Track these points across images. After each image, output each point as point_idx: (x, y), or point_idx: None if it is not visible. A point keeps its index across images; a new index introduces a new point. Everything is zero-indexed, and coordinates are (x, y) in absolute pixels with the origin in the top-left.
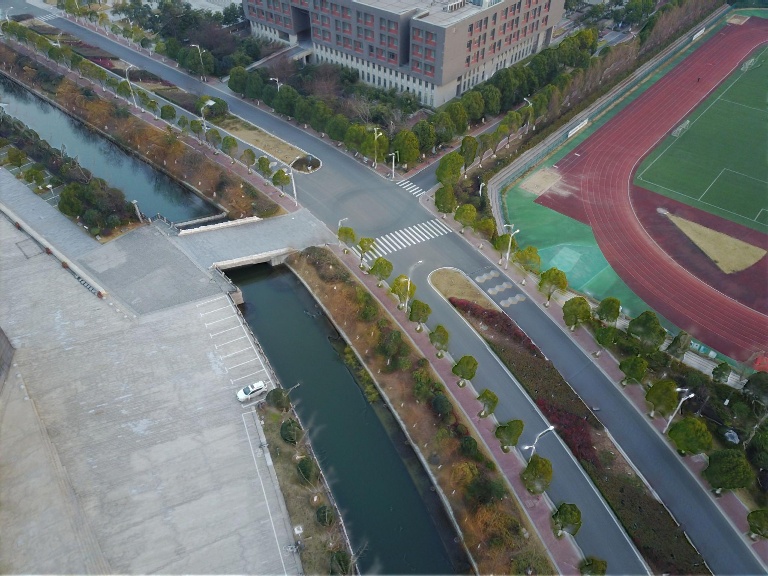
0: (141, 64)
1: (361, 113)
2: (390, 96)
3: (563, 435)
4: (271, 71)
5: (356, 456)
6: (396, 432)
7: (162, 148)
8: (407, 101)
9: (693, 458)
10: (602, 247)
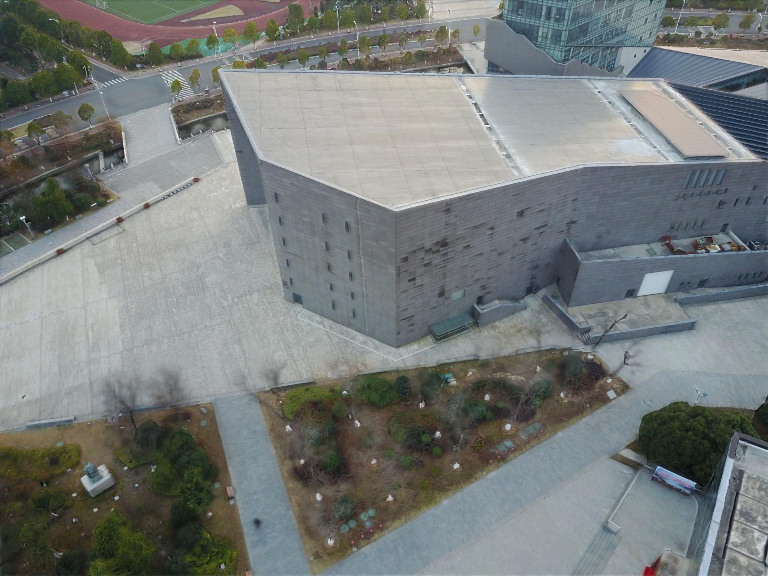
0: None
1: (8, 78)
2: None
3: (339, 49)
4: None
5: None
6: None
7: None
8: None
9: (352, 31)
10: None
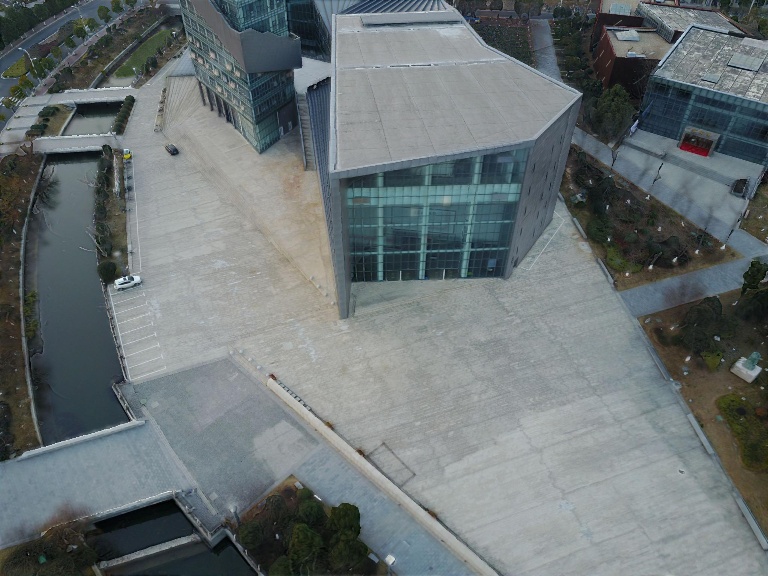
0: None
1: None
2: None
3: None
4: None
5: (73, 286)
6: (30, 274)
7: None
8: None
9: None
10: None
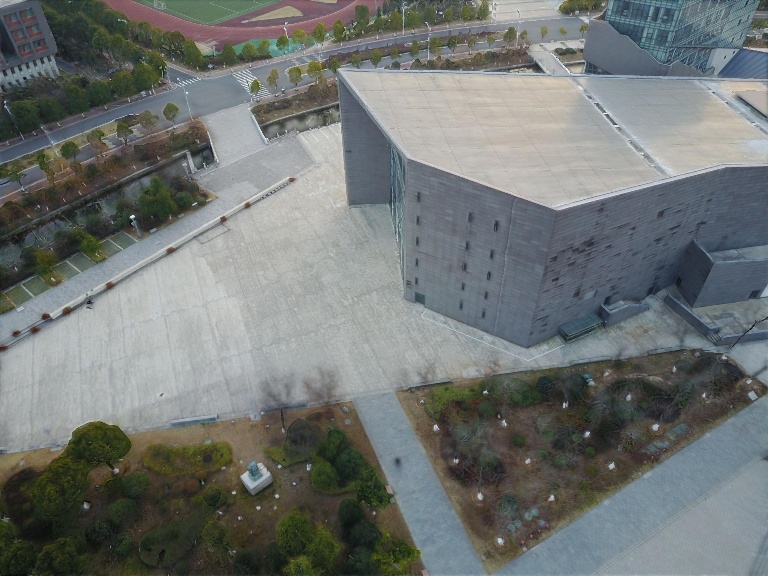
0: None
1: (88, 78)
2: (27, 89)
3: (408, 50)
4: None
5: None
6: None
7: (73, 177)
8: (48, 80)
9: (416, 32)
10: (273, 38)
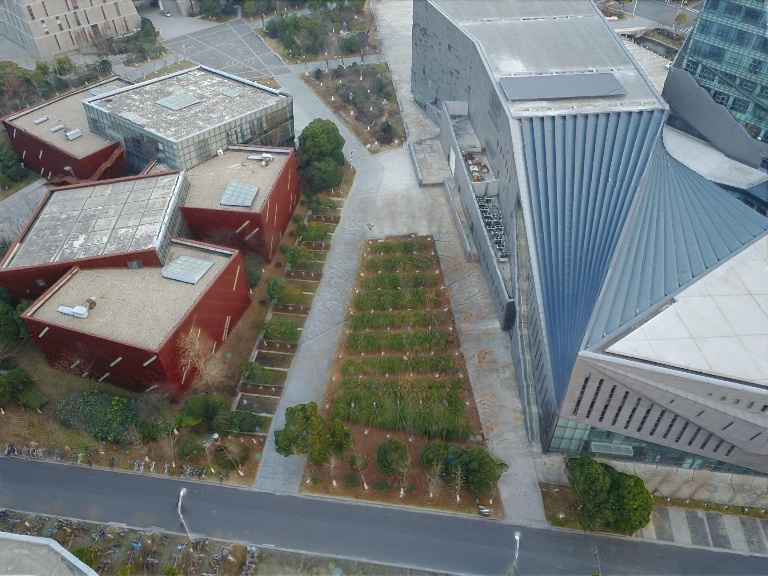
0: None
1: None
2: None
3: None
4: None
5: None
6: None
7: None
8: None
9: None
10: None
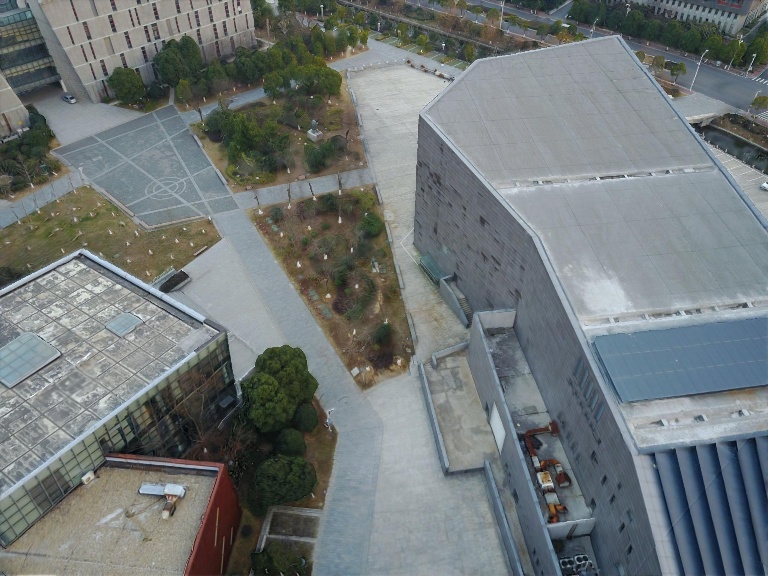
0: (472, 1)
1: (705, 30)
2: None
3: None
4: (593, 5)
5: None
6: None
7: None
8: None
9: None
10: None
